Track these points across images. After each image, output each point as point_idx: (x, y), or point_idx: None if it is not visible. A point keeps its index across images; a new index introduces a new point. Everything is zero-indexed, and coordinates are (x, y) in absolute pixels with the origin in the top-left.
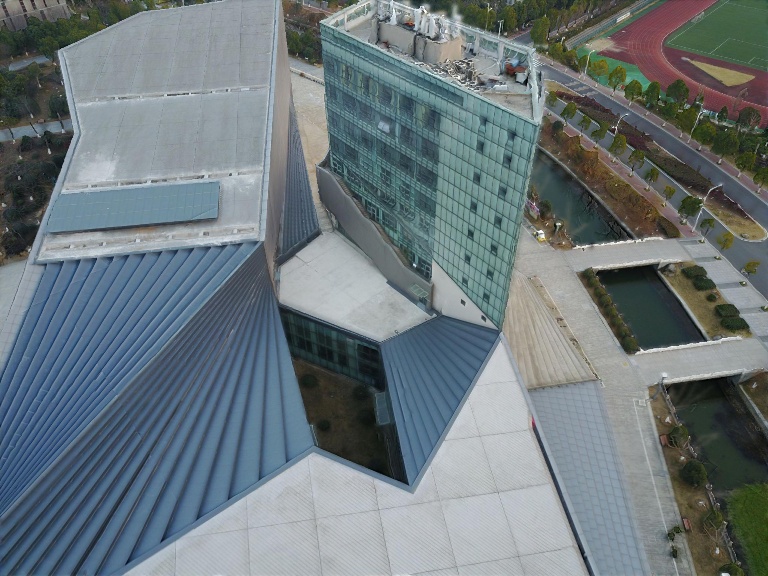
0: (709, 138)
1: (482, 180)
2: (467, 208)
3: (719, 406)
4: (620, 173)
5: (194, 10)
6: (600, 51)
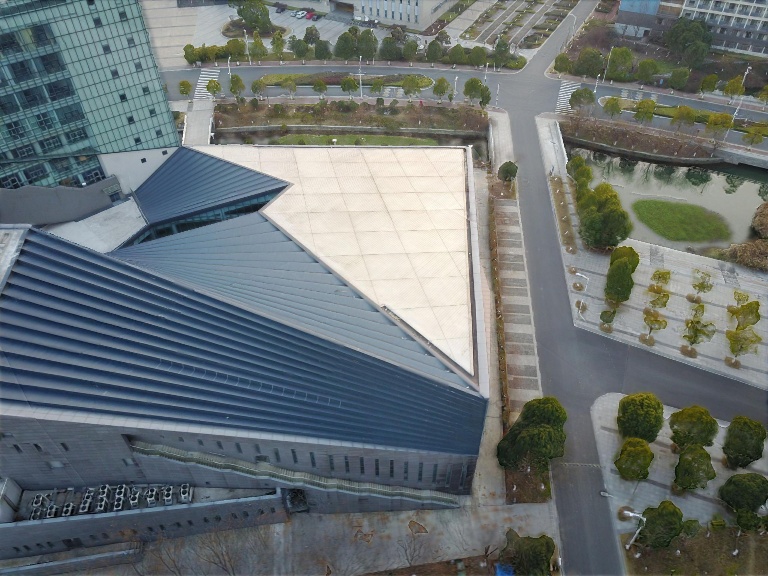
0: None
1: (111, 46)
2: (110, 79)
3: (226, 142)
4: None
5: None
6: None
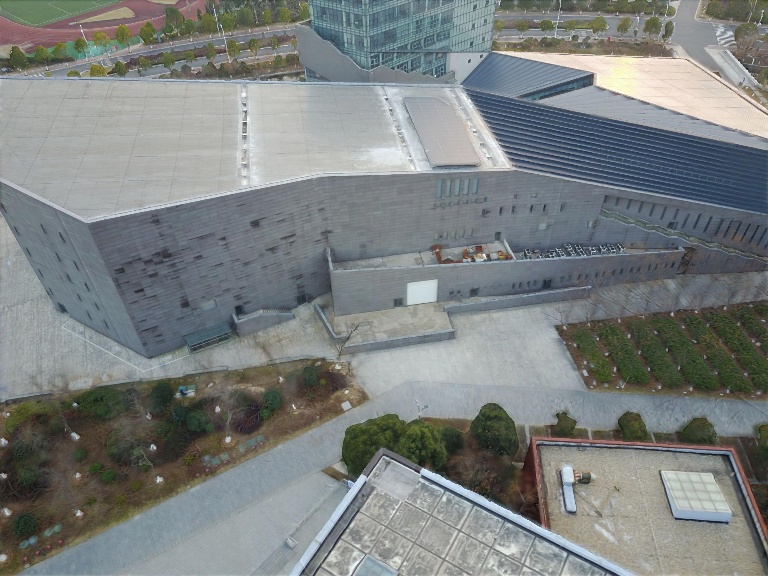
0: (235, 22)
1: None
2: None
3: None
4: (253, 62)
5: (2, 130)
6: (25, 52)
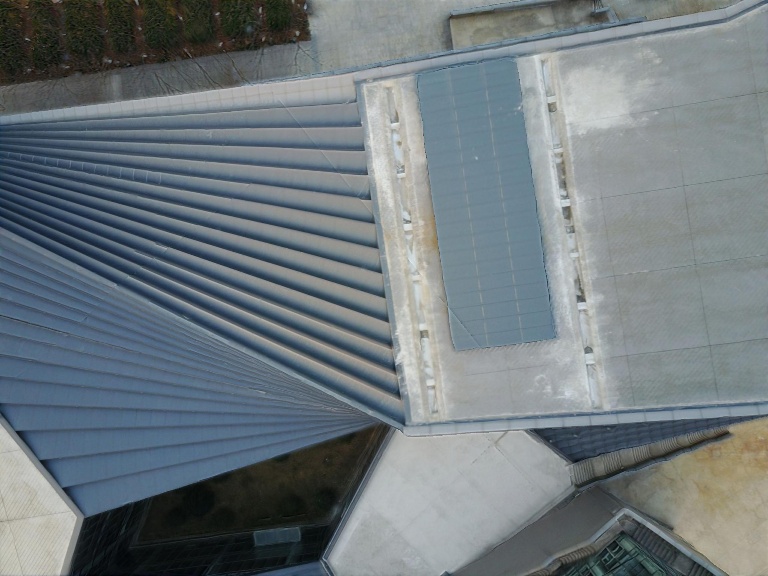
0: None
1: None
2: None
3: None
4: None
5: None
6: None
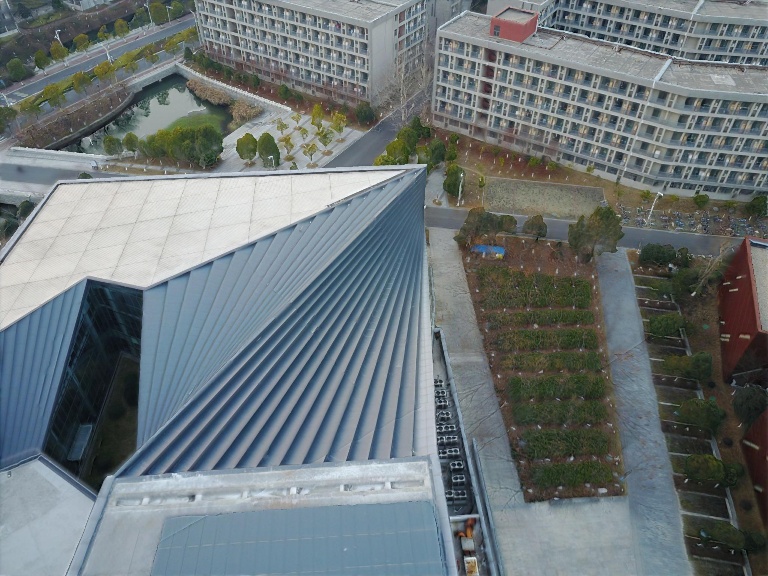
0: None
1: None
2: None
3: None
4: None
5: None
6: None
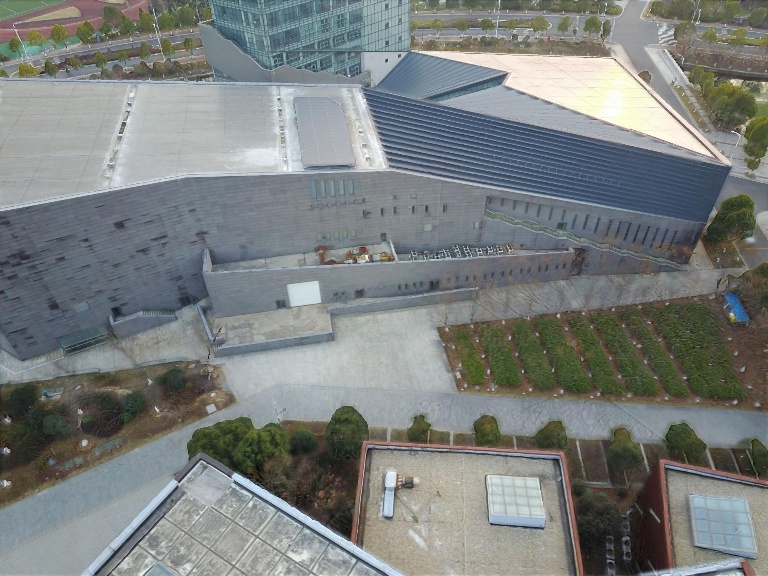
0: (175, 21)
1: None
2: None
3: None
4: (189, 61)
5: None
6: None
